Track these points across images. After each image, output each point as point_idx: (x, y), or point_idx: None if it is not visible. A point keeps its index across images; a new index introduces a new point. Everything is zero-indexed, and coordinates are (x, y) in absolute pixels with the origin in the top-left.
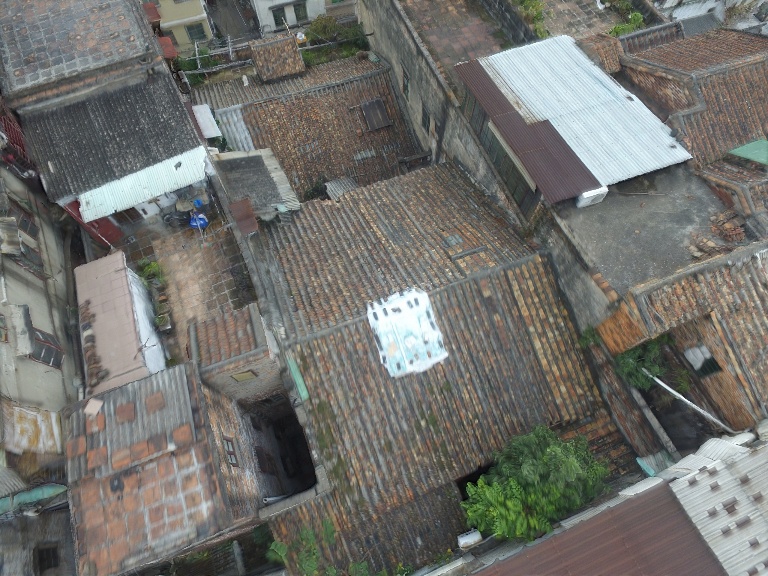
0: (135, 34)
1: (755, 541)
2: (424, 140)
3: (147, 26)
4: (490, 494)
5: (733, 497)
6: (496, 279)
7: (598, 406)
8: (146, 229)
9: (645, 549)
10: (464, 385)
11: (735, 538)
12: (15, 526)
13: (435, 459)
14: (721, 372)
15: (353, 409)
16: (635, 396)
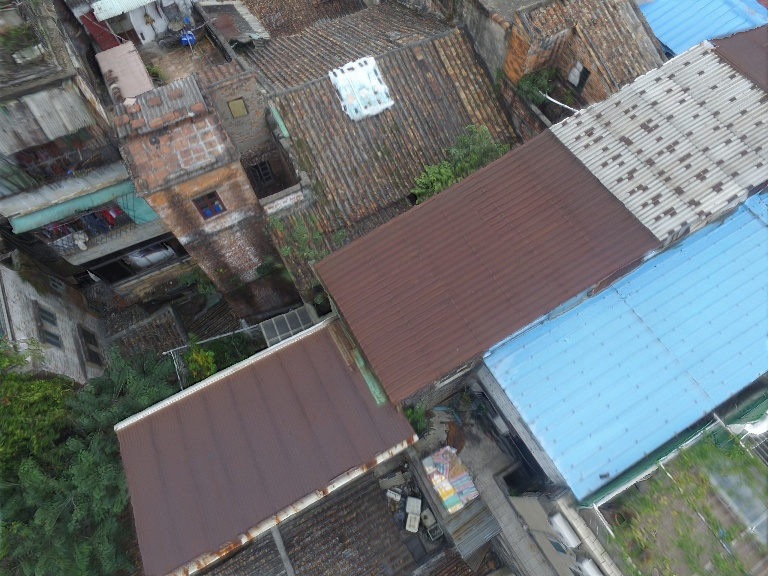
0: None
1: (606, 148)
2: (370, 2)
3: None
4: (429, 169)
5: (592, 127)
6: (426, 48)
7: (514, 141)
8: (145, 52)
9: (534, 168)
10: (409, 126)
11: (593, 149)
12: (60, 303)
13: (391, 181)
14: (590, 75)
15: (324, 144)
16: (533, 109)
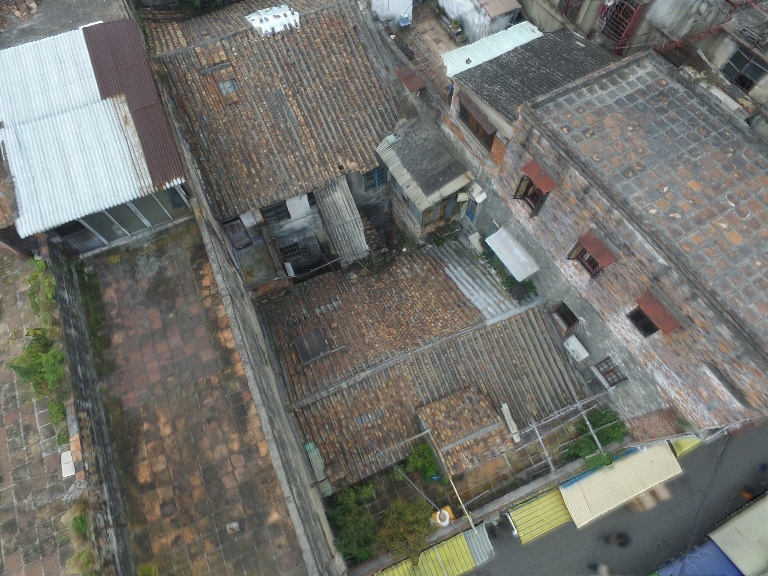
0: (565, 136)
1: None
2: None
3: (557, 149)
4: None
5: None
6: None
7: None
8: None
9: None
10: None
11: None
12: None
13: None
14: None
15: None
16: None
